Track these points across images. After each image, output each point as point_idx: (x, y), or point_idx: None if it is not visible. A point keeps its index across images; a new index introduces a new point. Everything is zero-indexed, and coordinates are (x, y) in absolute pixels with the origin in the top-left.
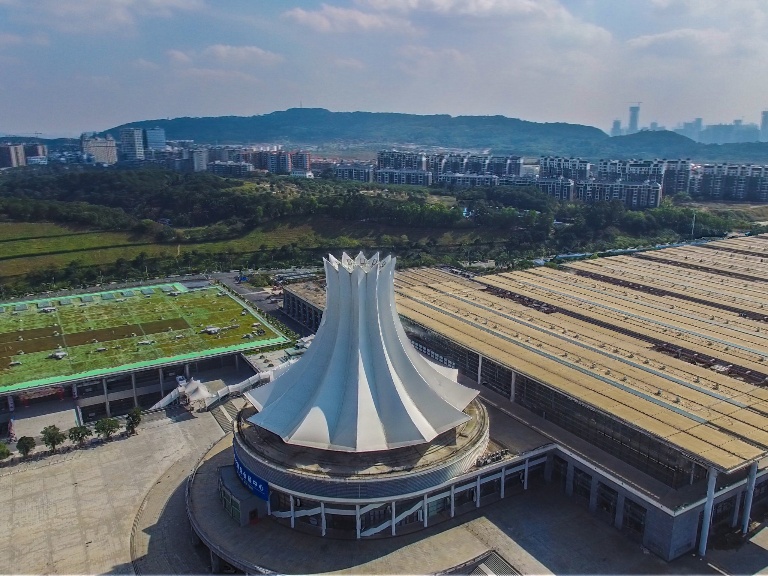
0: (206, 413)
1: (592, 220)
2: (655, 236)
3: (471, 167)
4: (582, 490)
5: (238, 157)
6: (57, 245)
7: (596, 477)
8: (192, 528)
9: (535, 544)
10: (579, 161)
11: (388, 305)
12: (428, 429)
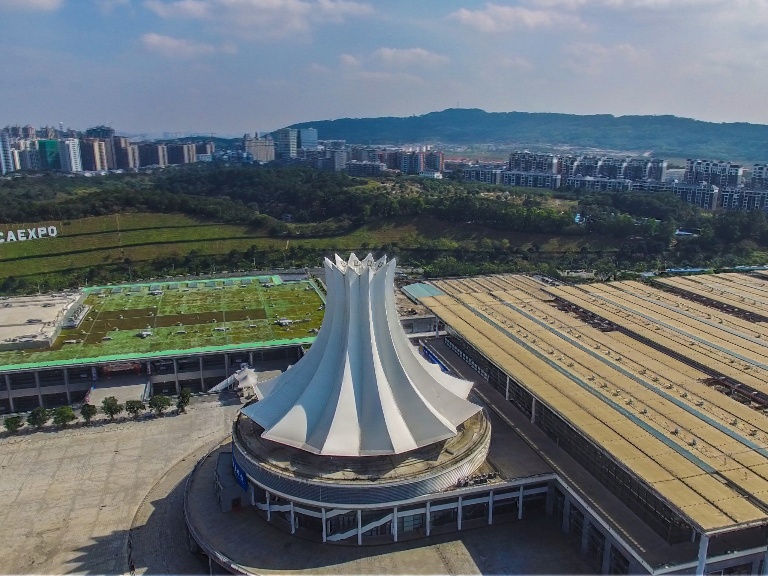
0: None
1: (723, 232)
2: None
3: (606, 170)
4: (576, 529)
5: (374, 157)
6: (183, 235)
7: (587, 517)
8: None
9: None
10: (729, 165)
11: (383, 309)
12: (408, 441)
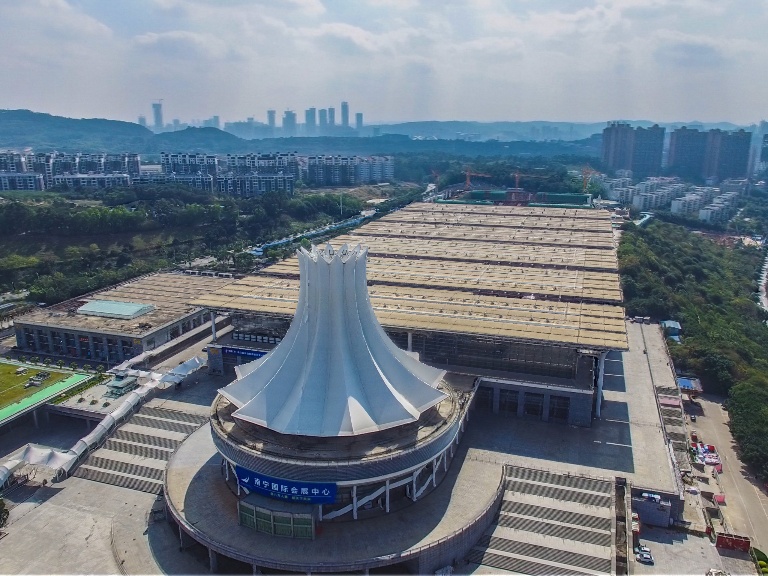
0: (69, 480)
1: (268, 210)
2: (316, 219)
3: (85, 167)
4: (508, 405)
5: None
6: None
7: (523, 390)
8: (258, 569)
9: (521, 450)
10: (206, 156)
11: None
12: None
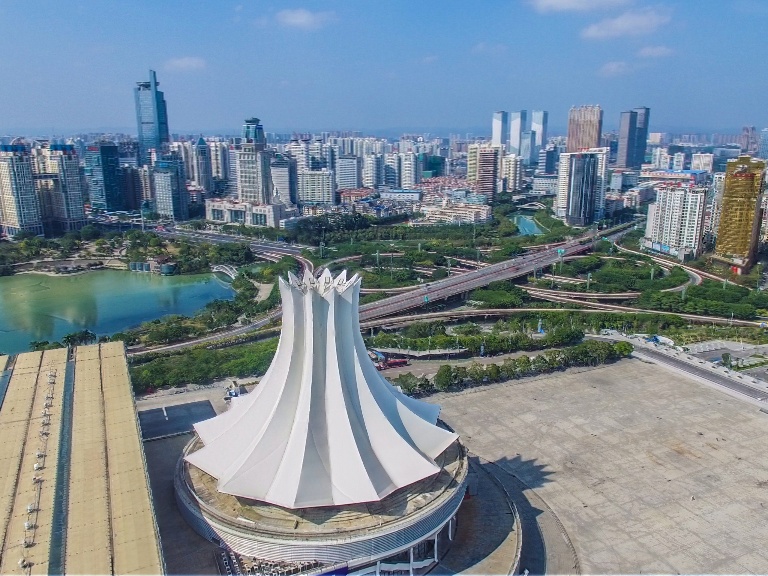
0: None
1: None
2: None
3: None
4: None
5: None
6: None
7: None
8: None
9: None
10: None
11: None
12: None
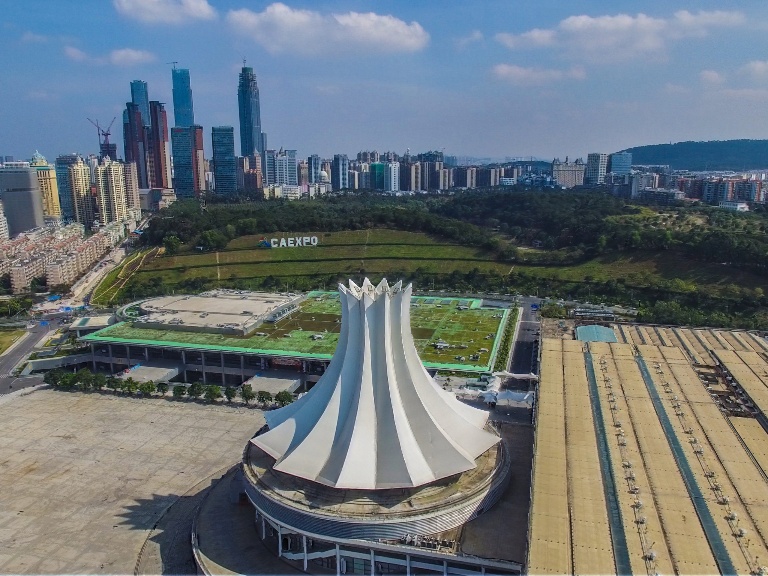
0: None
1: None
2: None
3: None
4: None
5: (673, 184)
6: (419, 252)
7: None
8: None
9: None
10: None
11: (383, 338)
12: (368, 479)
